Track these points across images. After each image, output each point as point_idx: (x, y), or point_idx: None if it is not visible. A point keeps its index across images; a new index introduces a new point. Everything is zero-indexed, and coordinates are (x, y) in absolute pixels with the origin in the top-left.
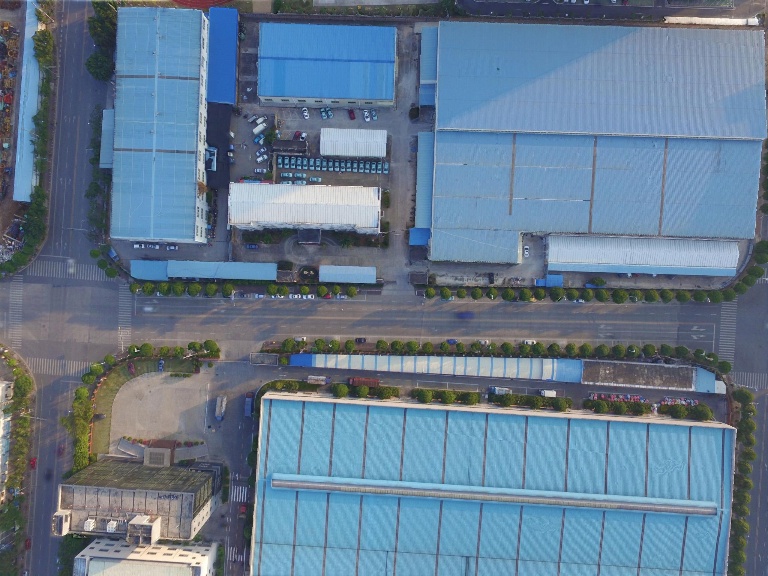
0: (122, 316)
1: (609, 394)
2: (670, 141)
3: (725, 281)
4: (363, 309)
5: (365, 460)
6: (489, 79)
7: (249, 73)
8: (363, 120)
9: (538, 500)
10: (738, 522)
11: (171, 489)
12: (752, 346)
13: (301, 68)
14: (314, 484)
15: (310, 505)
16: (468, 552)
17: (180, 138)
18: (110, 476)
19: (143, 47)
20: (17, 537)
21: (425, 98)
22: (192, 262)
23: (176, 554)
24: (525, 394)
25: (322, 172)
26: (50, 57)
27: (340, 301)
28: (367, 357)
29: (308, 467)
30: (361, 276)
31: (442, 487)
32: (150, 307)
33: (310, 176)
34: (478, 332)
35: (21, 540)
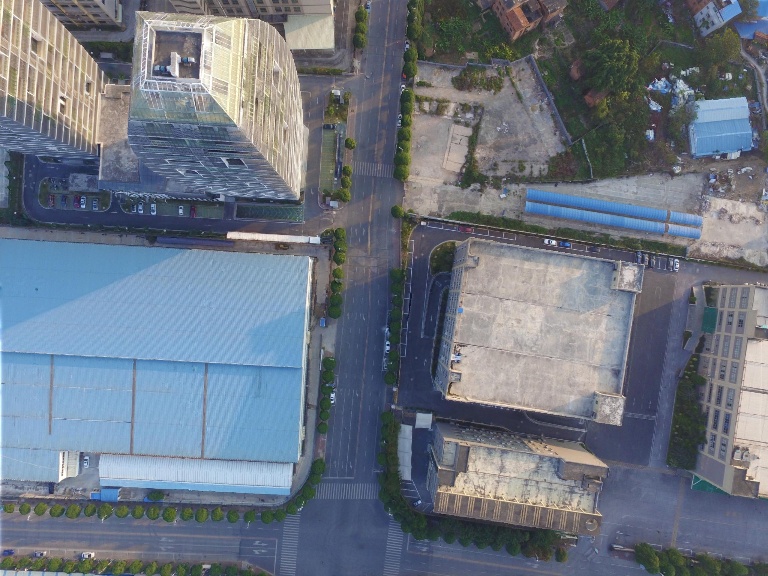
0: None
1: None
2: (210, 366)
3: (288, 495)
4: None
5: None
6: (26, 299)
7: None
8: None
9: None
10: None
11: None
12: (313, 562)
13: None
14: None
15: None
16: None
17: None
18: None
19: None
20: None
21: None
22: None
23: None
24: None
25: None
26: None
27: None
28: None
29: None
30: None
31: None
32: None
33: None
34: (37, 542)
35: None
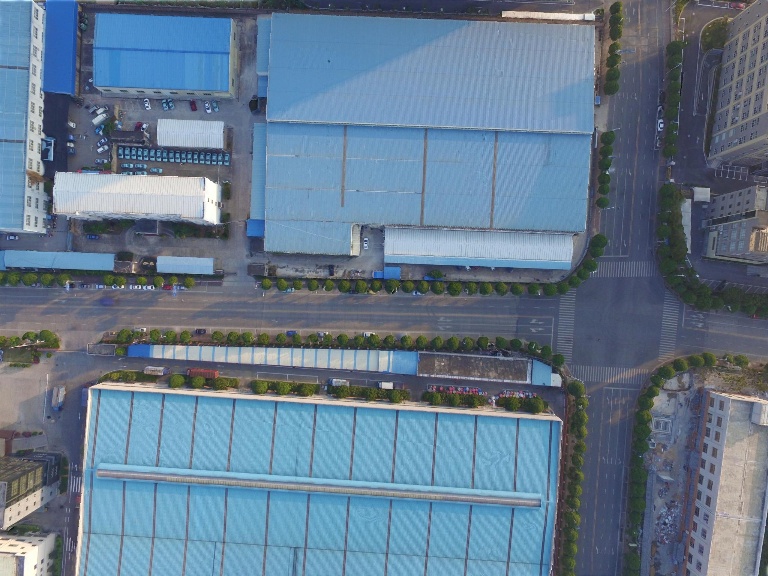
0: None
1: (448, 386)
2: (500, 134)
3: (564, 275)
4: (204, 300)
5: (193, 450)
6: (320, 71)
7: (91, 64)
8: (205, 111)
9: (363, 491)
10: (569, 514)
11: None
12: (590, 339)
13: (136, 59)
14: (140, 474)
15: (138, 495)
16: (296, 543)
17: (9, 127)
18: None
19: None
20: None
21: (263, 90)
22: (29, 252)
23: (6, 544)
24: (365, 386)
25: (163, 163)
26: None
27: None
28: (204, 348)
29: (140, 457)
30: (198, 267)
31: (267, 478)
32: None
33: (151, 167)
34: (318, 324)
35: None
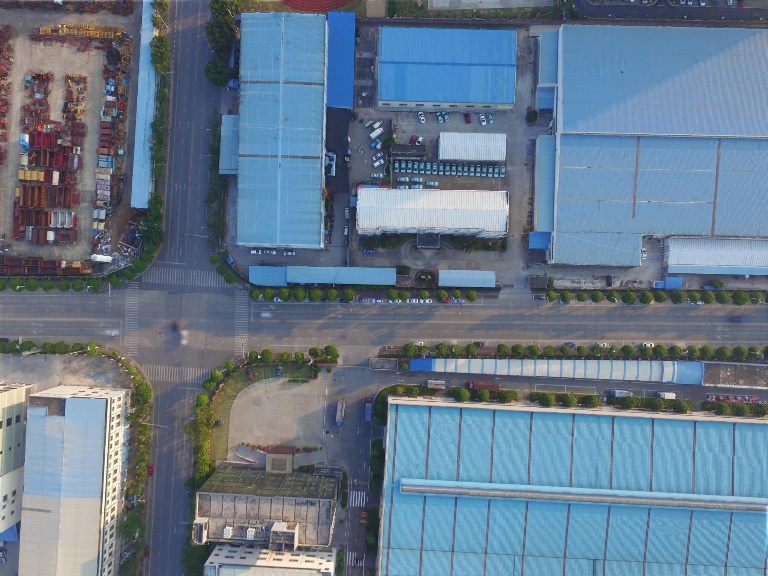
0: (238, 322)
1: (727, 396)
2: None
3: None
4: (480, 313)
5: (492, 464)
6: (613, 82)
7: (364, 77)
8: (479, 124)
9: (667, 502)
10: None
11: (308, 496)
12: None
13: (422, 72)
14: (443, 489)
15: (438, 510)
16: (595, 555)
17: (305, 144)
18: (241, 483)
19: (267, 52)
20: (136, 544)
21: (544, 101)
22: (311, 267)
23: (302, 560)
24: (643, 396)
25: (438, 176)
26: (167, 63)
27: (459, 305)
28: (487, 361)
29: None
30: (481, 280)
31: (571, 490)
32: (267, 313)
33: (426, 180)
34: (596, 335)
35: (141, 547)
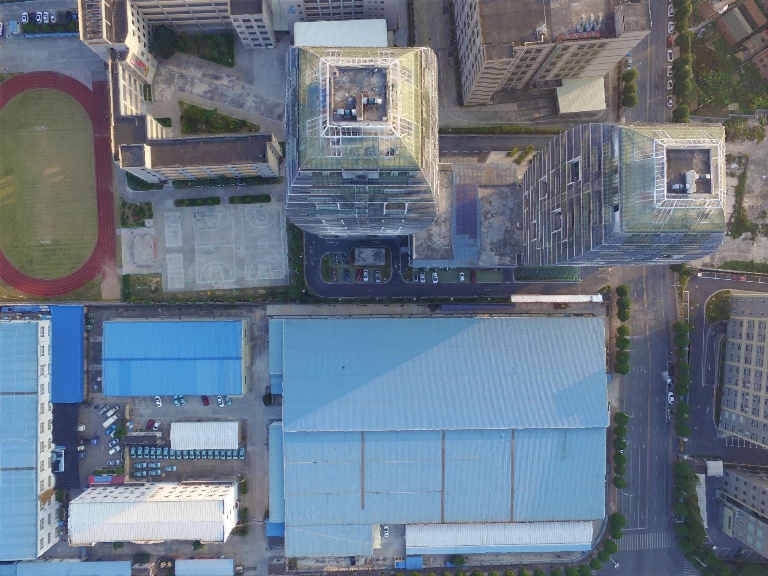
0: None
1: None
2: (516, 431)
3: None
4: None
5: None
6: (334, 378)
7: (99, 362)
8: (217, 405)
9: None
10: None
11: None
12: None
13: (146, 368)
14: None
15: None
16: None
17: (18, 455)
18: None
19: None
20: None
21: (276, 387)
22: (43, 564)
23: None
24: None
25: (177, 460)
26: None
27: None
28: None
29: None
30: (218, 570)
31: None
32: None
33: (165, 464)
34: None
35: None
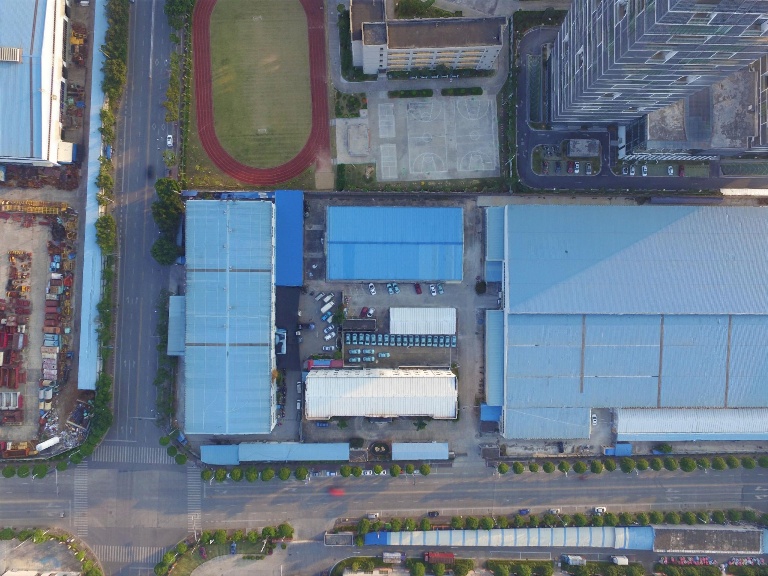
0: (191, 499)
1: (678, 556)
2: (734, 317)
3: None
4: (435, 482)
5: None
6: (558, 262)
7: (314, 250)
8: (429, 294)
9: None
10: None
11: None
12: None
13: (370, 251)
14: None
15: None
16: None
17: (253, 331)
18: None
19: (213, 241)
20: None
21: (492, 274)
22: (263, 445)
23: None
24: (597, 560)
25: (390, 347)
26: (112, 242)
27: (413, 478)
28: (442, 533)
29: None
30: (434, 453)
31: None
32: (220, 489)
33: (378, 351)
34: (549, 501)
35: None
